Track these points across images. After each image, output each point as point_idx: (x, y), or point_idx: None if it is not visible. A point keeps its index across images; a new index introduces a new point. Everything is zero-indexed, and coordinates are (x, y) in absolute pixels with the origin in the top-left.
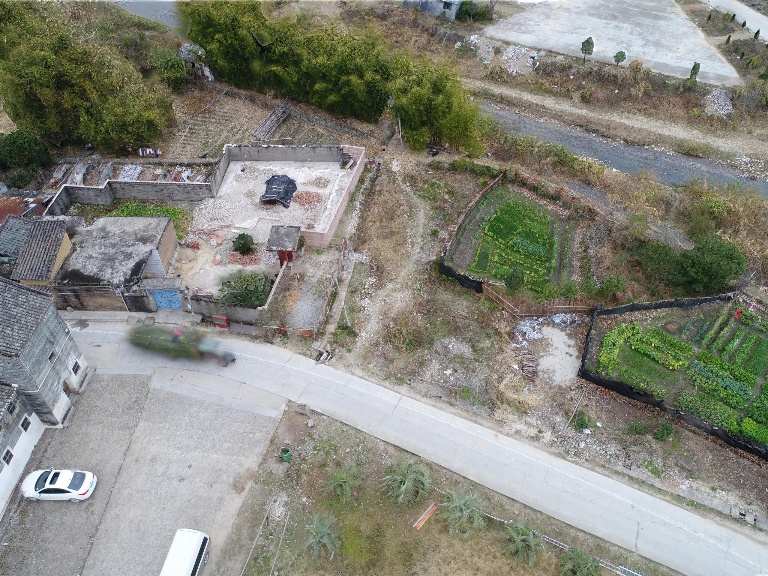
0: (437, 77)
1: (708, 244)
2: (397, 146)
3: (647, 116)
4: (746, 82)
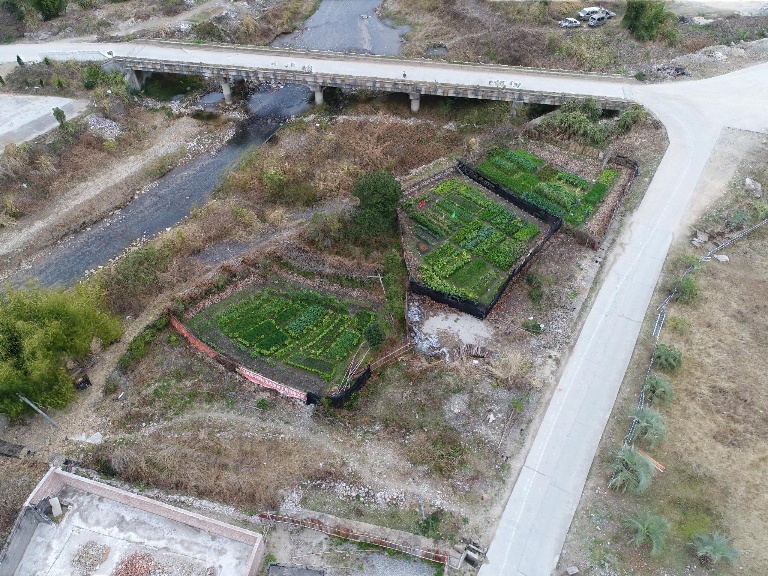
0: (16, 309)
1: (377, 184)
2: (31, 432)
3: (83, 180)
4: (86, 98)
